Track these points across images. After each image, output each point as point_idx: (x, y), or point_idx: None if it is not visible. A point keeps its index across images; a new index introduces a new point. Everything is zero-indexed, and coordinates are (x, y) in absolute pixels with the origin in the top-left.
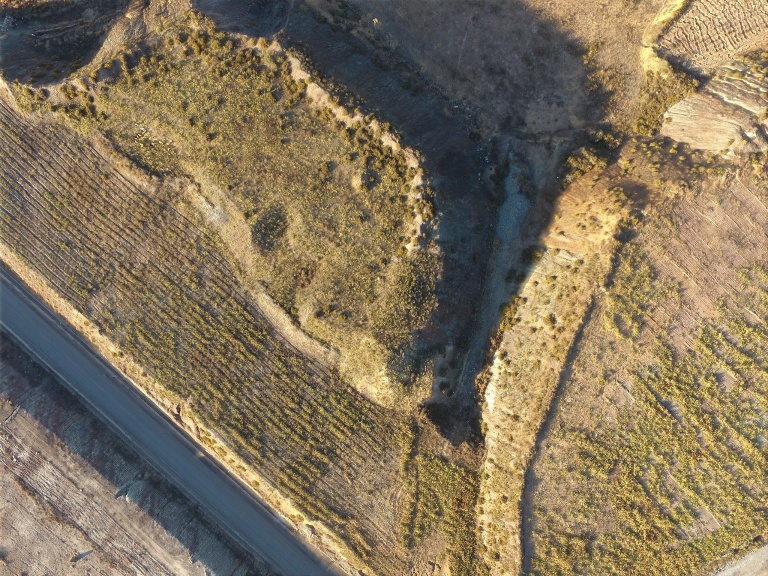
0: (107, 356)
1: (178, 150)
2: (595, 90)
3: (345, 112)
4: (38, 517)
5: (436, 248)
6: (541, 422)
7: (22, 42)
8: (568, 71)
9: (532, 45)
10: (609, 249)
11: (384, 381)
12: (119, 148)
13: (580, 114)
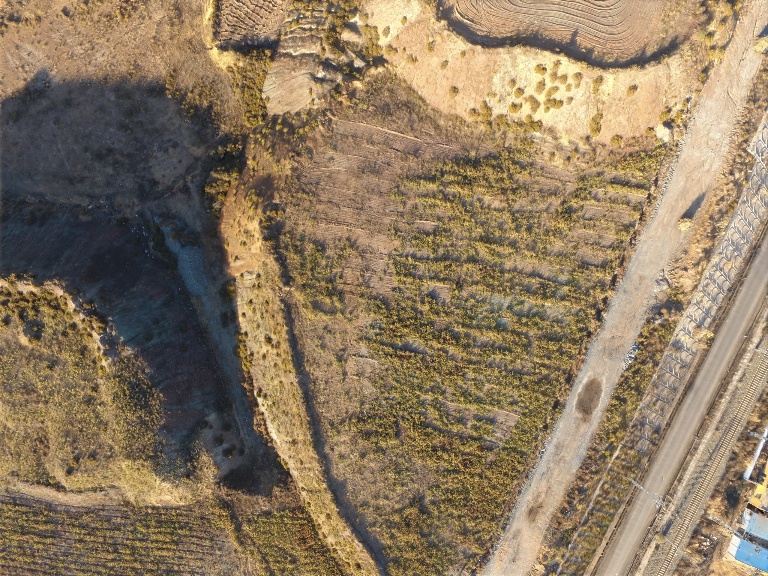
0: None
1: None
2: (194, 114)
3: None
4: None
5: (126, 349)
6: (310, 434)
7: None
8: (163, 113)
9: (118, 112)
10: (267, 252)
11: (166, 486)
12: None
13: (196, 142)
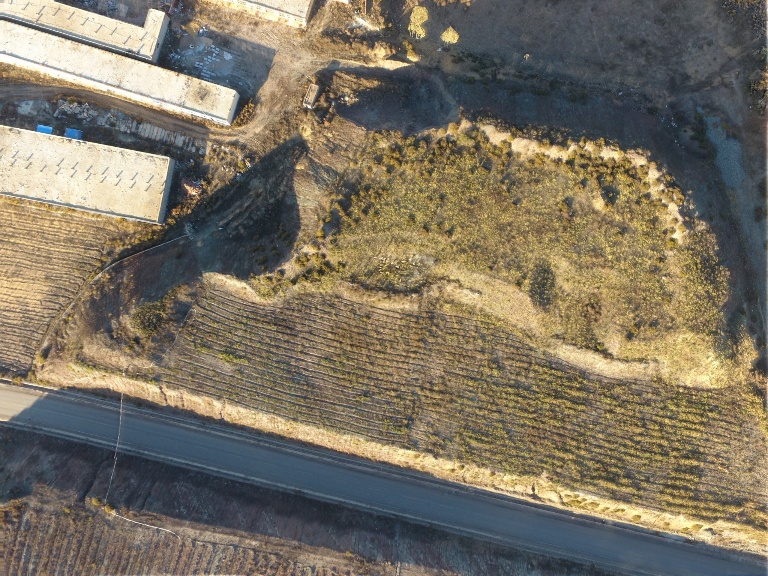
0: (441, 476)
1: (422, 260)
2: (735, 15)
3: (561, 148)
4: None
5: (701, 224)
6: None
7: (218, 240)
8: (700, 11)
9: (656, 5)
10: None
11: (714, 365)
12: (369, 286)
13: (733, 42)
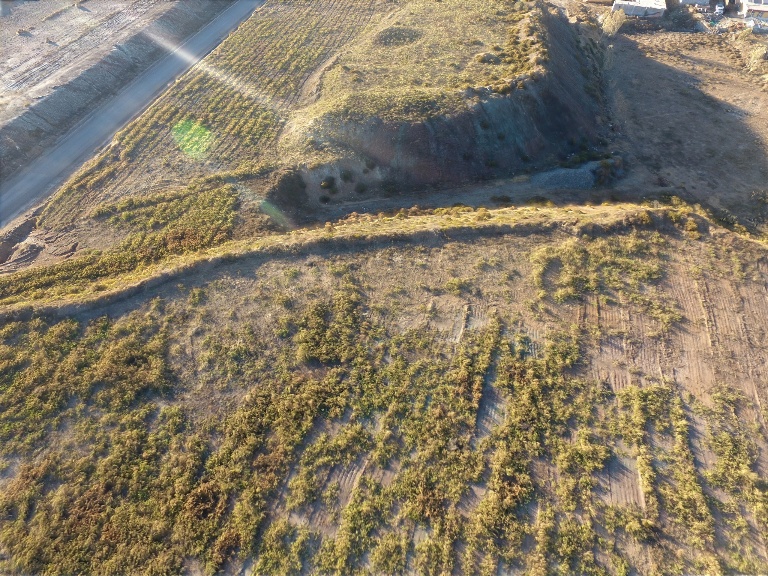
0: None
1: (416, 0)
2: (764, 202)
3: (527, 29)
4: (87, 23)
5: (473, 103)
6: (343, 236)
7: None
8: (748, 181)
9: (728, 150)
10: (628, 213)
11: (307, 125)
12: None
13: (726, 202)
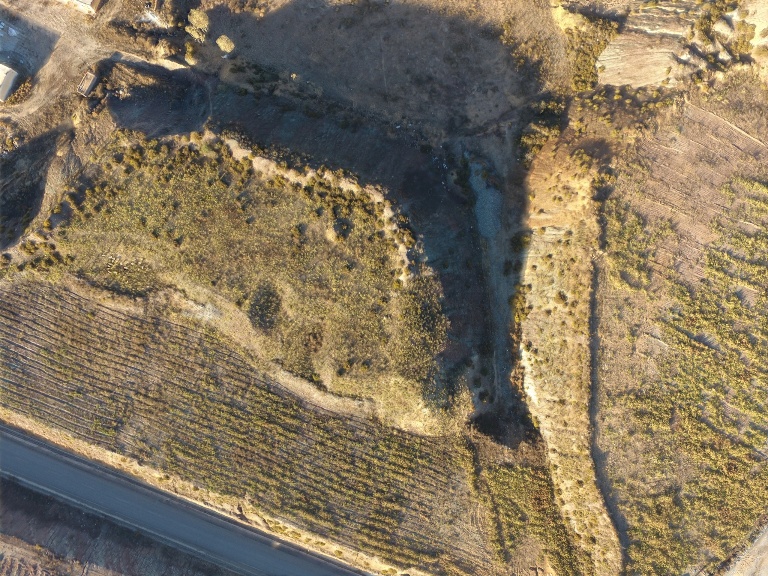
0: (154, 483)
1: (152, 265)
2: (523, 65)
3: (297, 174)
4: None
5: (429, 270)
6: (588, 399)
7: None
8: (491, 56)
9: (448, 44)
10: (592, 212)
11: (425, 413)
12: (95, 283)
13: (517, 92)
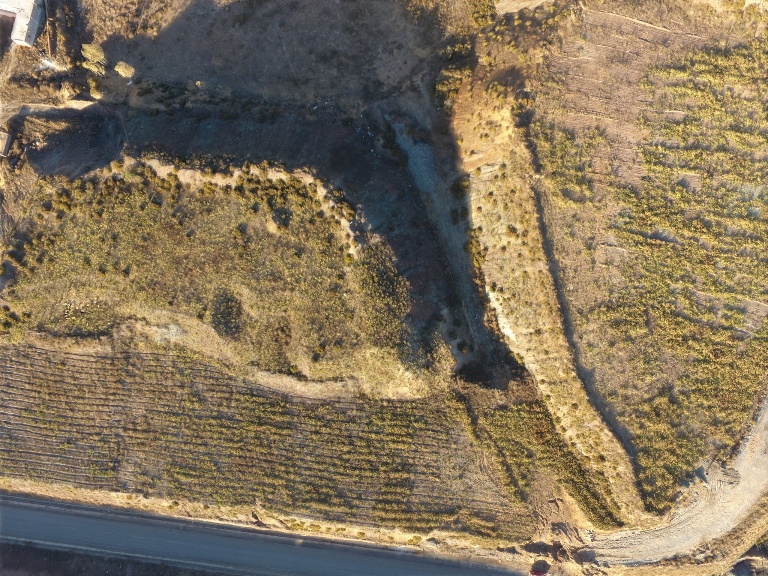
0: (166, 512)
1: (107, 302)
2: (420, 16)
3: (223, 176)
4: None
5: (375, 237)
6: (561, 322)
7: None
8: (387, 15)
9: (343, 14)
10: (518, 140)
11: (408, 376)
12: (57, 333)
13: (421, 44)
